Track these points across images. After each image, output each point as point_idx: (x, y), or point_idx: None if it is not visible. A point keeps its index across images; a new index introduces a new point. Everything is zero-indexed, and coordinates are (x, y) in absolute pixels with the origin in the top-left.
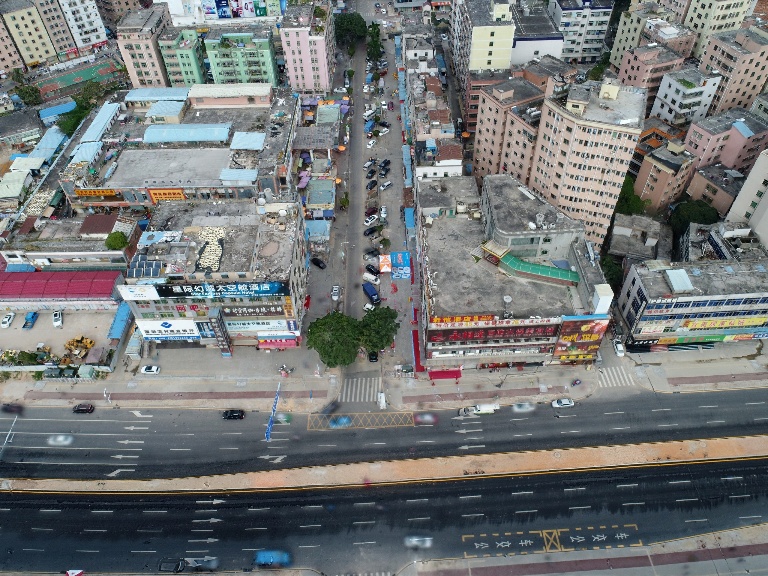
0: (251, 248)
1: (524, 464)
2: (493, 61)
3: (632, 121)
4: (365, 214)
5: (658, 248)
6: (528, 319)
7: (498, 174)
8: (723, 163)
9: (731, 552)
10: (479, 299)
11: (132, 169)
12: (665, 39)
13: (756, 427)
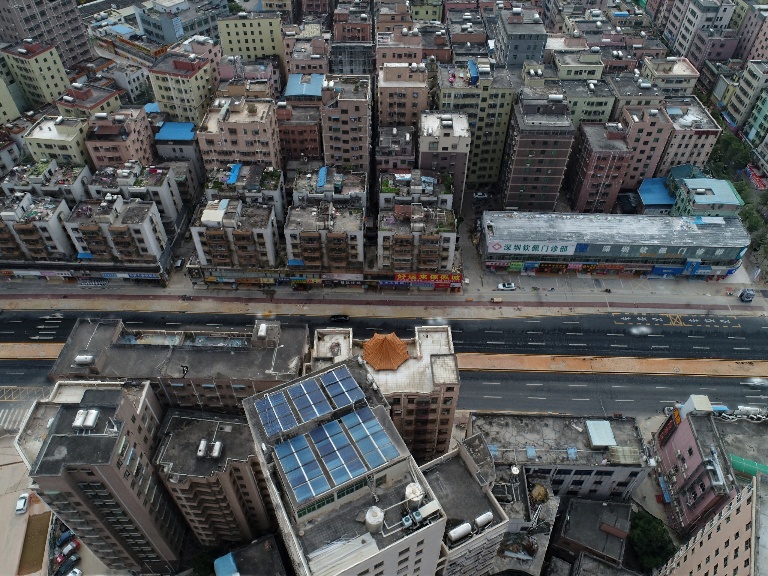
0: None
1: (704, 365)
2: None
3: None
4: None
5: None
6: (766, 411)
7: None
8: None
9: (553, 304)
10: None
11: None
12: None
13: (502, 377)
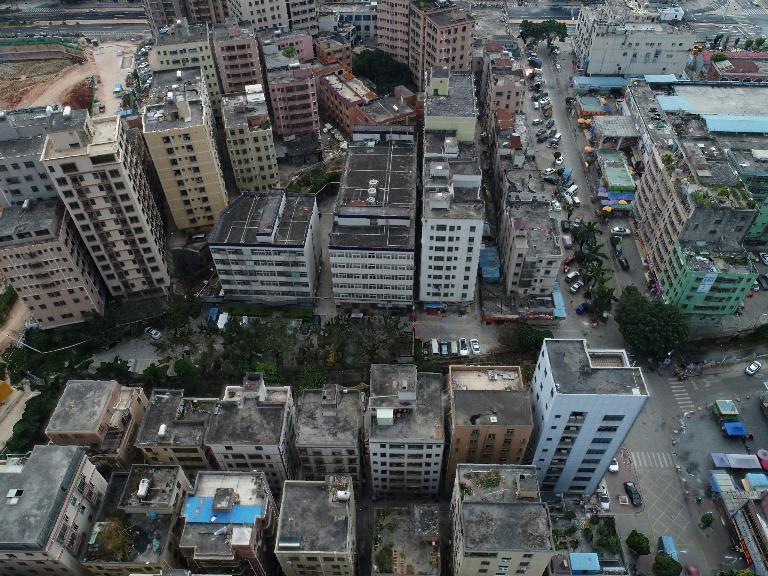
0: (611, 6)
1: None
2: None
3: None
4: None
5: None
6: None
7: None
8: None
9: None
10: (478, 13)
11: (767, 101)
12: None
13: None
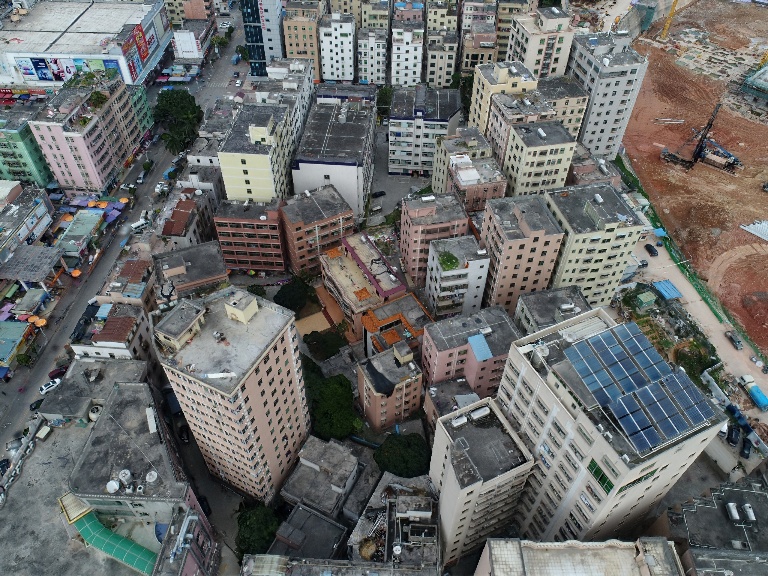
0: None
1: None
2: (253, 190)
3: (227, 375)
4: (48, 376)
5: (351, 493)
6: None
7: (133, 383)
8: (467, 379)
9: None
10: None
11: None
12: (462, 185)
13: None
